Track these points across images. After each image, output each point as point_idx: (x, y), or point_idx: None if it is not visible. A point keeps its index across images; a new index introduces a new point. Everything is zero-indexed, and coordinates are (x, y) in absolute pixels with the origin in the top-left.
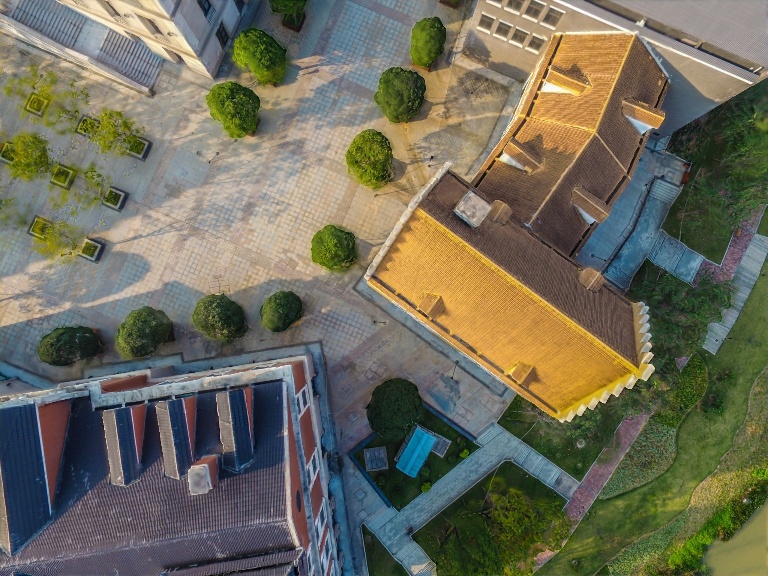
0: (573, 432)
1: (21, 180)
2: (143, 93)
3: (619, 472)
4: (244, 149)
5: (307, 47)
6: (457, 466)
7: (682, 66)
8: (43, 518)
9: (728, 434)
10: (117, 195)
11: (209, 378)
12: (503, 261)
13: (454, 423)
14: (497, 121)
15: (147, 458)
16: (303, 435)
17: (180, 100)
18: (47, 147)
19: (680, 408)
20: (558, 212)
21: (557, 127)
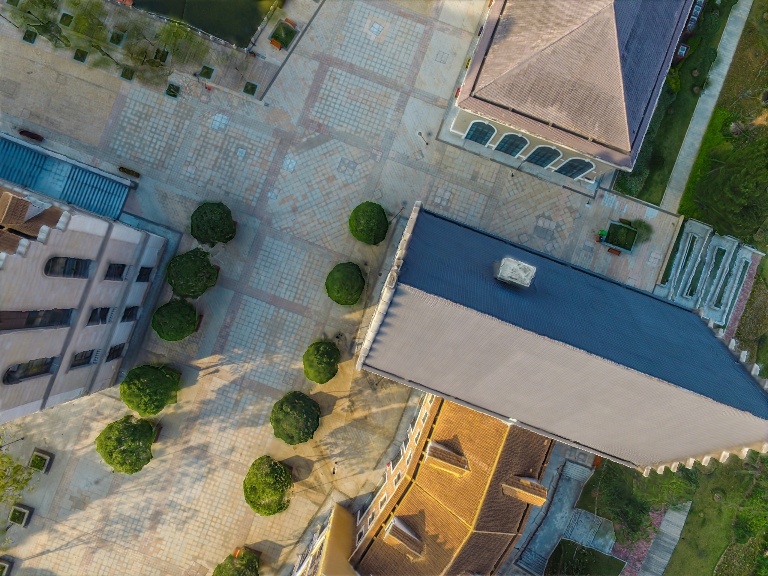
0: None
1: None
2: None
3: None
4: None
5: (206, 346)
6: None
7: None
8: None
9: None
10: (21, 514)
11: None
12: None
13: None
14: (403, 412)
15: None
16: None
17: (80, 408)
18: None
19: None
20: None
21: (438, 507)
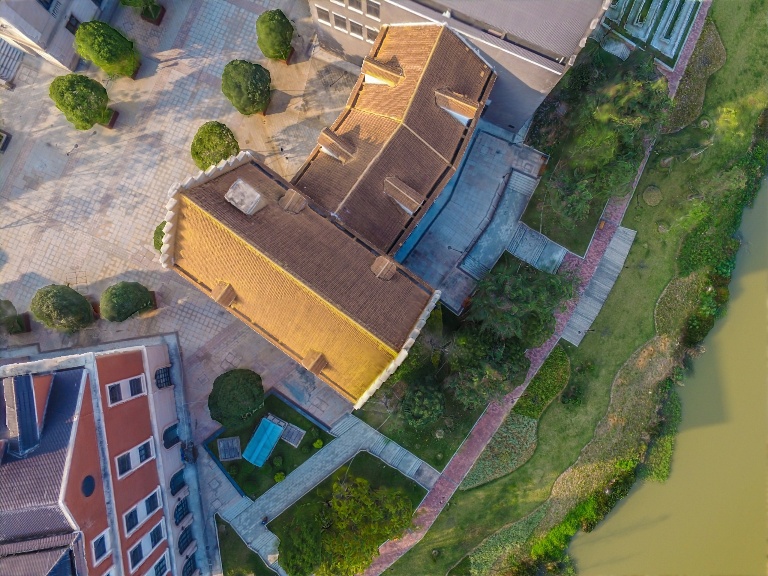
0: (414, 422)
1: None
2: (3, 86)
3: (479, 463)
4: (103, 141)
5: (167, 40)
6: (313, 456)
7: (498, 57)
8: None
9: (589, 425)
10: None
11: (11, 365)
12: (271, 248)
13: (308, 413)
14: None
15: None
16: (121, 423)
17: (40, 93)
18: None
19: (541, 399)
20: (370, 202)
21: (373, 118)
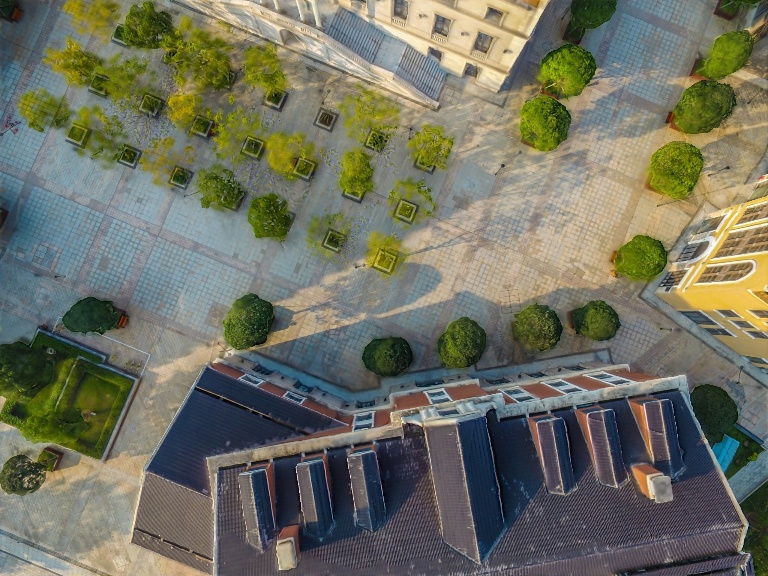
0: None
1: (314, 194)
2: (429, 107)
3: None
4: (528, 161)
5: None
6: (741, 469)
7: None
8: (499, 526)
9: None
10: (410, 208)
11: (608, 388)
12: None
13: (742, 427)
14: None
15: (576, 467)
16: None
17: (464, 113)
18: (337, 161)
19: None
20: None
21: None
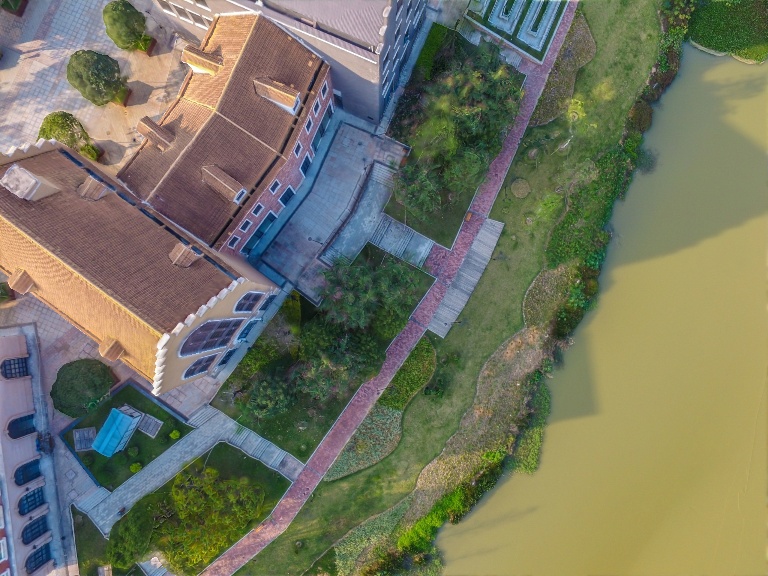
0: (260, 412)
1: None
2: None
3: (344, 454)
4: None
5: (29, 31)
6: (172, 447)
7: (320, 46)
8: None
9: (454, 417)
10: None
11: None
12: (47, 233)
13: (165, 404)
14: None
15: None
16: None
17: None
18: None
19: (405, 391)
20: (187, 190)
21: (195, 106)
